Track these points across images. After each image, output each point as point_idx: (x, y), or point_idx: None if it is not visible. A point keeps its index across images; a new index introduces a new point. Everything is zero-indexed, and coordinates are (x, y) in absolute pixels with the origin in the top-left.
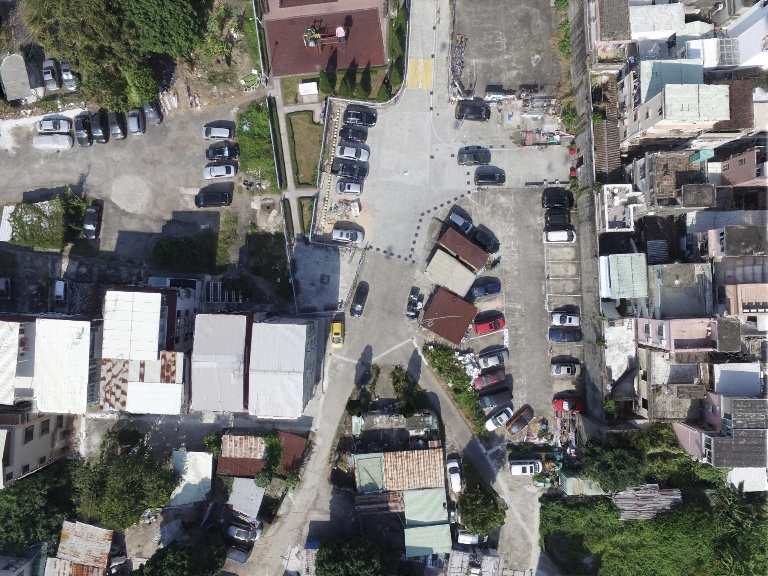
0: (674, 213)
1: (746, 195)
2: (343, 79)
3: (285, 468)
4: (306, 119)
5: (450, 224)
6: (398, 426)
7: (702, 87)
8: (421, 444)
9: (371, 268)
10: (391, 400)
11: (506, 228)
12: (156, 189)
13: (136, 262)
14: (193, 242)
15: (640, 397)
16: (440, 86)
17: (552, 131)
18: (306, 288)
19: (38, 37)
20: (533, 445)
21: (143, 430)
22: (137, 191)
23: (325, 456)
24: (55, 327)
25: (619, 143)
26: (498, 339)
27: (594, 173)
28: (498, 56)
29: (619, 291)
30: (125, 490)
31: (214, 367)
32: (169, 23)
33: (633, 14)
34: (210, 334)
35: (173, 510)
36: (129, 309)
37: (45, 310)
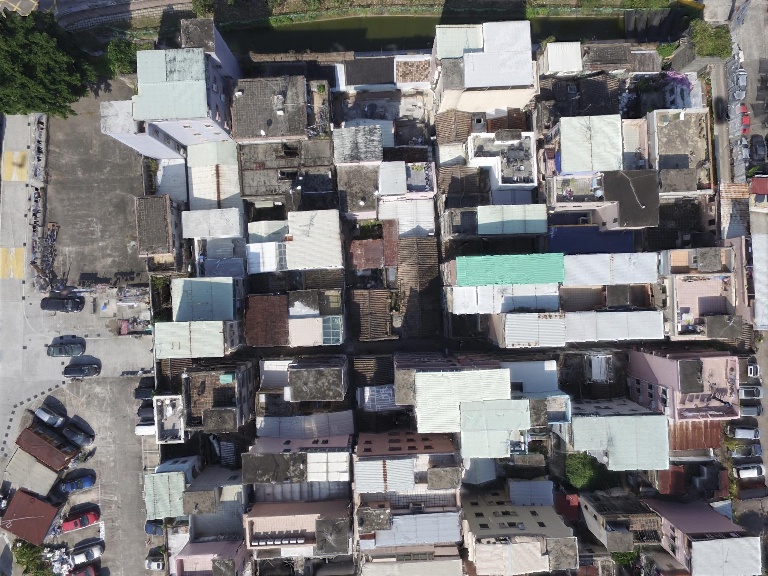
0: None
1: None
2: None
3: None
4: None
5: None
6: None
7: (193, 324)
8: None
9: None
10: None
11: (102, 419)
12: None
13: None
14: None
15: None
16: None
17: (149, 319)
18: None
19: None
20: None
21: None
22: None
23: None
24: None
25: None
26: (94, 532)
27: (155, 379)
28: (92, 243)
29: (154, 512)
30: None
31: None
32: None
33: (188, 219)
34: None
35: None
36: None
37: None
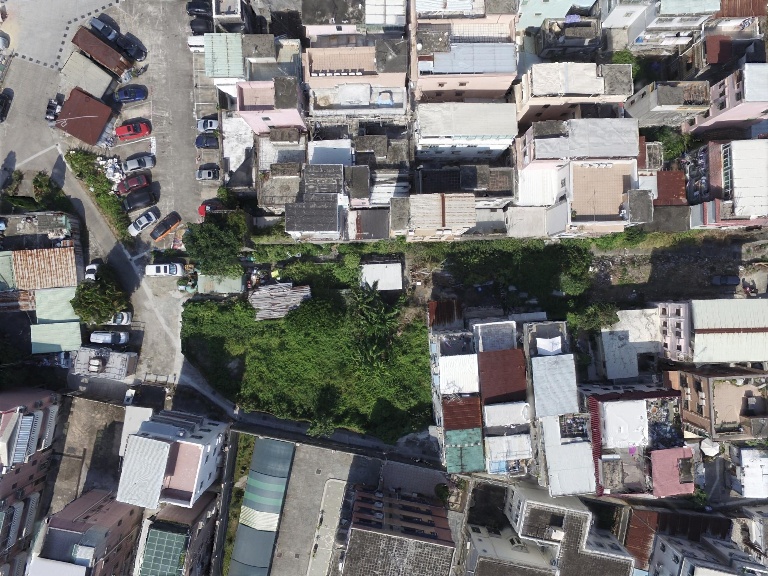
0: (291, 5)
1: None
2: None
3: None
4: None
5: (95, 31)
6: (42, 232)
7: None
8: (59, 246)
9: (16, 75)
10: None
11: (154, 37)
12: None
13: None
14: None
15: None
16: None
17: None
18: None
19: None
20: (180, 252)
21: None
22: None
23: None
24: None
25: None
26: (145, 146)
27: None
28: None
29: (213, 69)
30: None
31: None
32: None
33: None
34: None
35: None
36: None
37: None
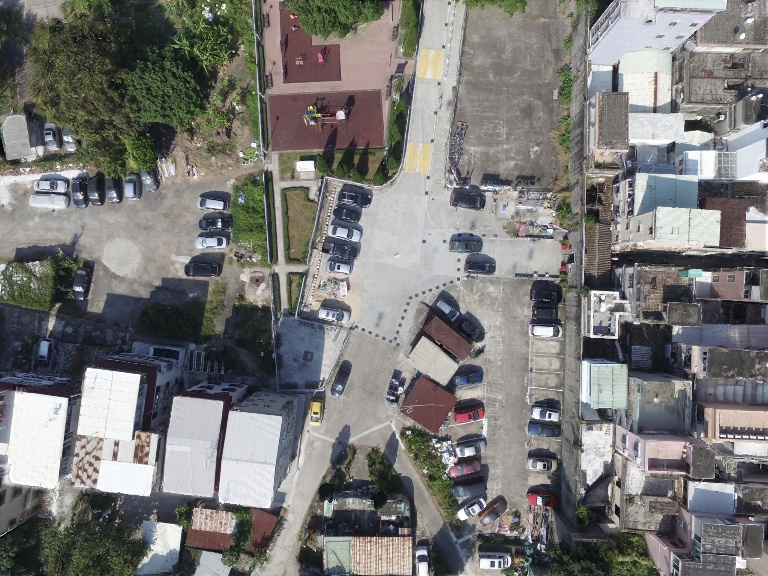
0: None
1: (735, 304)
2: (340, 164)
3: (254, 544)
4: (301, 195)
5: (437, 310)
6: (370, 508)
7: (694, 212)
8: (392, 529)
9: (355, 348)
10: (365, 482)
11: (493, 317)
12: (147, 254)
13: (122, 326)
14: (180, 310)
15: (613, 503)
16: (437, 171)
17: (546, 224)
18: (289, 363)
19: (41, 100)
20: (504, 537)
21: (116, 494)
22: (128, 255)
23: (295, 533)
24: (33, 402)
25: (611, 246)
26: (477, 428)
27: (583, 276)
28: (497, 145)
29: (598, 401)
30: (91, 564)
31: (188, 451)
32: (171, 98)
33: (633, 121)
34: (186, 417)
35: (140, 575)
36: (108, 387)
37: (28, 367)
